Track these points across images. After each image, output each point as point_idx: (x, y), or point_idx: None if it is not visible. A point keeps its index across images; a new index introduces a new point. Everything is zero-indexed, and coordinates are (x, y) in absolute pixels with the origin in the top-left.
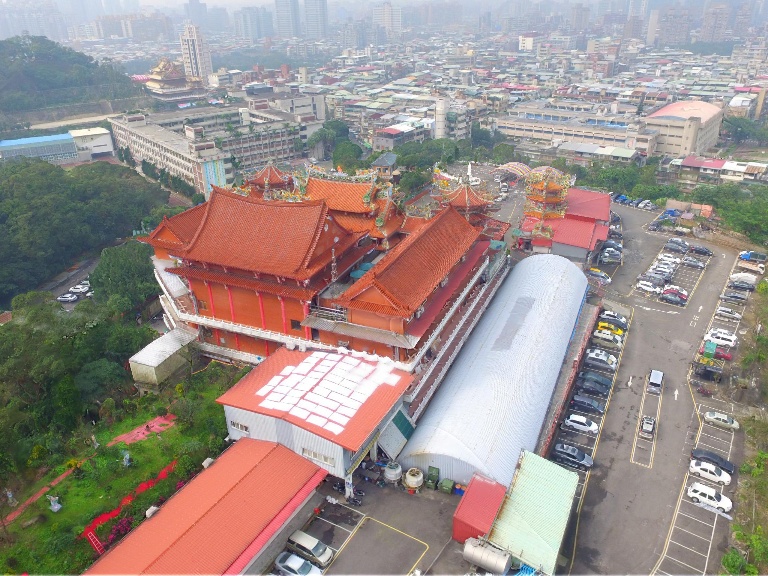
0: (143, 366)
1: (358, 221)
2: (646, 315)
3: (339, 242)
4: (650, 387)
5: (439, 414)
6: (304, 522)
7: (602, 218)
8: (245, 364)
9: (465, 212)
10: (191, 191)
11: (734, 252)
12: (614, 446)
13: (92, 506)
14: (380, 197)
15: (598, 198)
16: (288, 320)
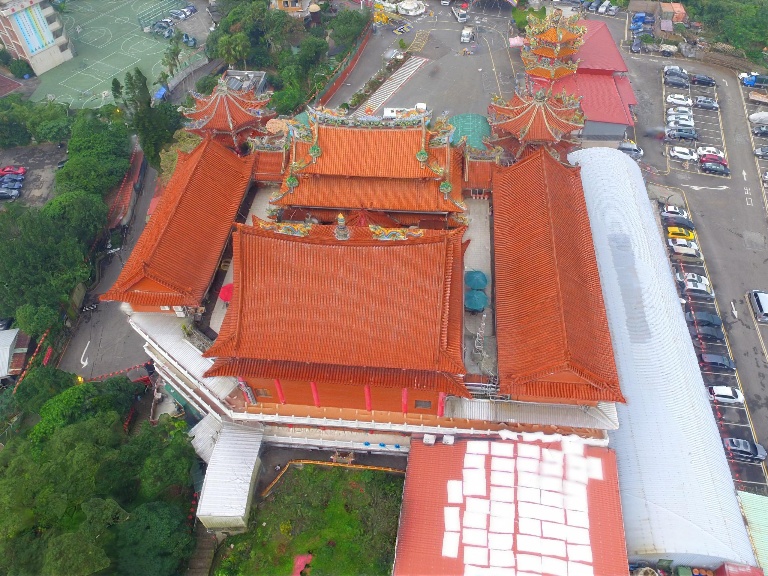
0: (222, 517)
1: (411, 187)
2: (700, 199)
3: None
4: (763, 318)
5: (632, 473)
6: None
7: (620, 68)
8: (347, 454)
9: (542, 142)
10: (4, 58)
11: (732, 74)
12: (767, 416)
13: None
14: (434, 145)
15: (596, 31)
16: (411, 401)
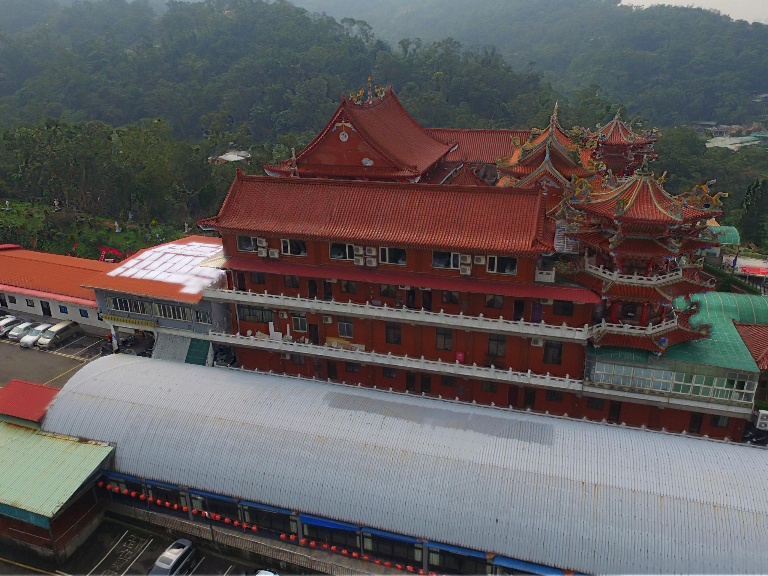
0: None
1: None
2: None
3: (371, 167)
4: None
5: None
6: (100, 334)
7: None
8: None
9: None
10: None
11: None
12: None
13: (121, 242)
14: None
15: None
16: None
